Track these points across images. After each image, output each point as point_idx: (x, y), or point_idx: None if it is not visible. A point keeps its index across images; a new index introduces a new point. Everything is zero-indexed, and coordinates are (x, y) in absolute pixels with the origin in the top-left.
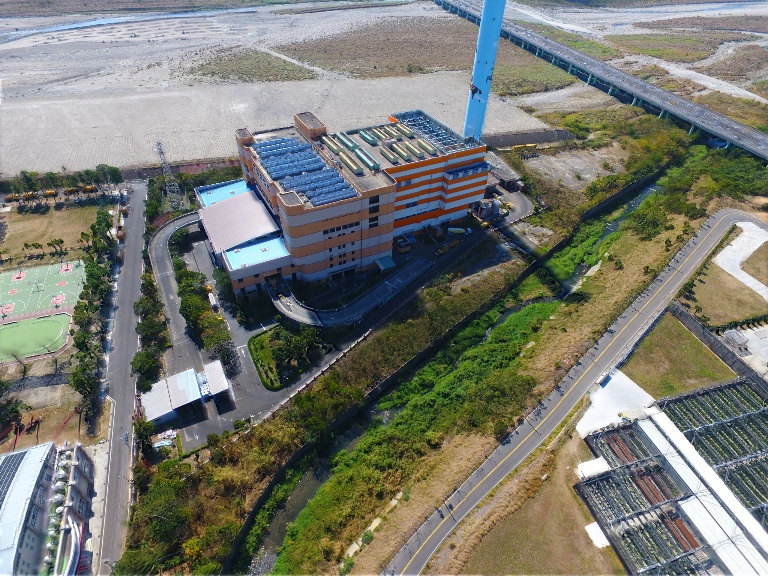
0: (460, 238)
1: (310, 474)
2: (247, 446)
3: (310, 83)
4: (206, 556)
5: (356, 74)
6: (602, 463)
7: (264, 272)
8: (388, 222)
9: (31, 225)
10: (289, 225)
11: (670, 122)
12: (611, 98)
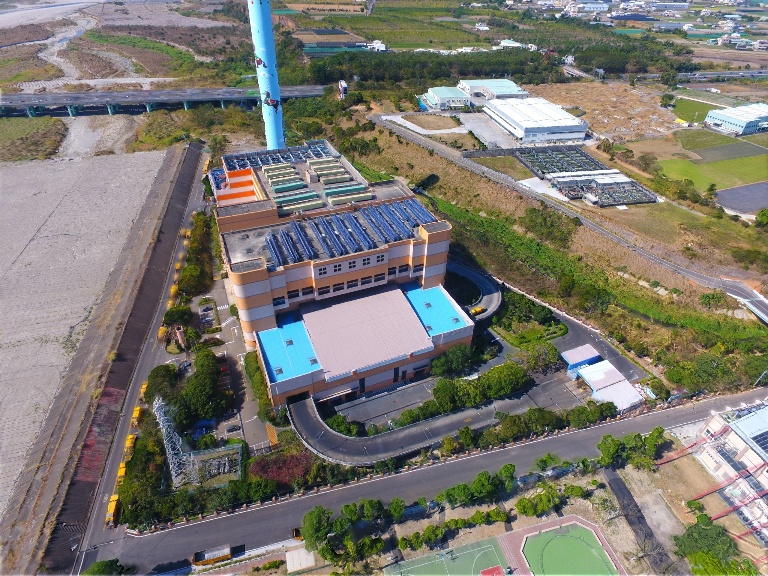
0: None
1: None
2: None
3: None
4: (718, 340)
5: None
6: (588, 194)
7: None
8: None
9: None
10: None
11: (211, 105)
12: (121, 116)
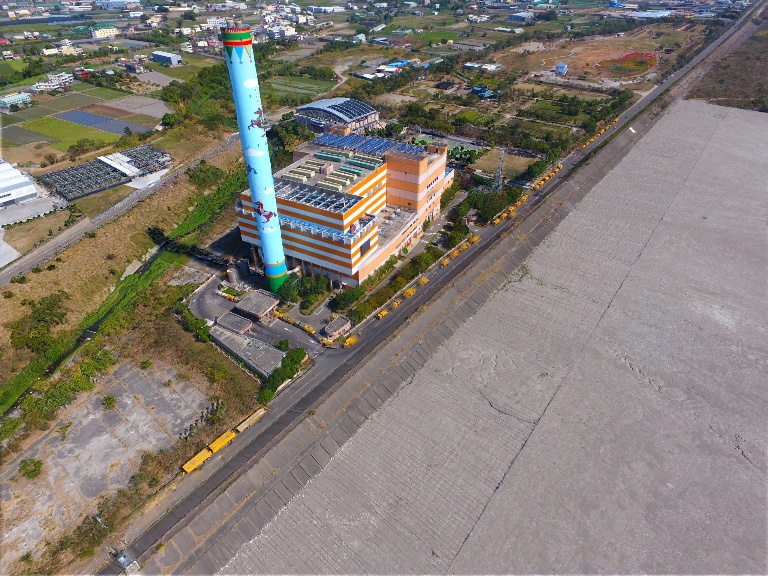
0: None
1: None
2: None
3: None
4: None
5: None
6: None
7: None
8: None
9: (519, 161)
10: None
11: None
12: None
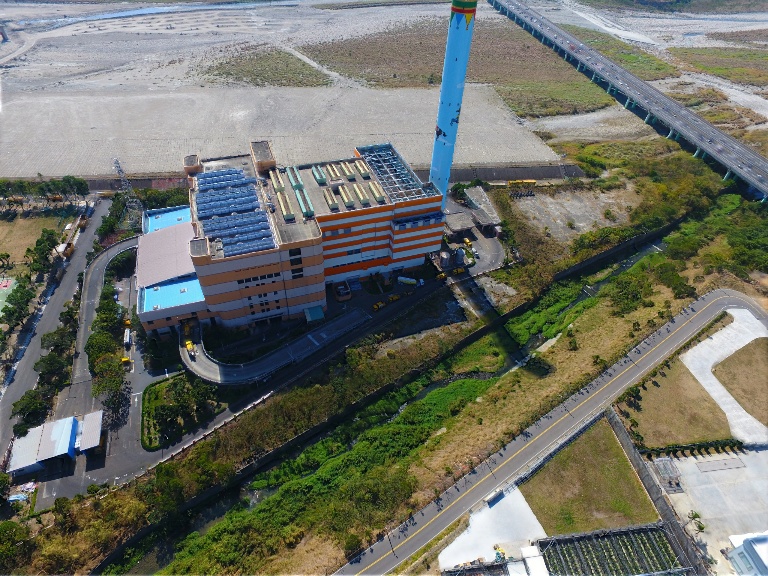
0: (408, 290)
1: (152, 555)
2: (93, 516)
3: (320, 90)
4: None
5: (372, 82)
6: None
7: (177, 315)
8: (315, 273)
9: None
10: (197, 274)
11: (702, 164)
12: (646, 127)
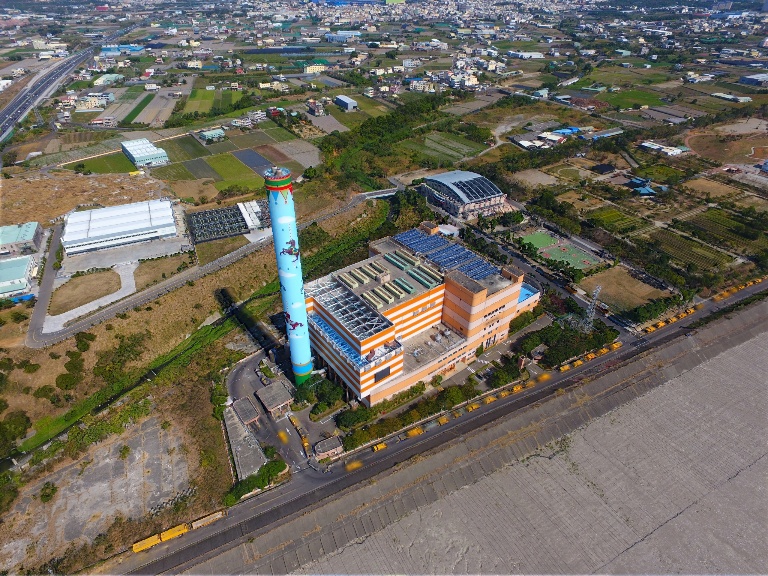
0: None
1: None
2: None
3: None
4: None
5: None
6: None
7: None
8: None
9: (641, 290)
10: None
11: None
12: None
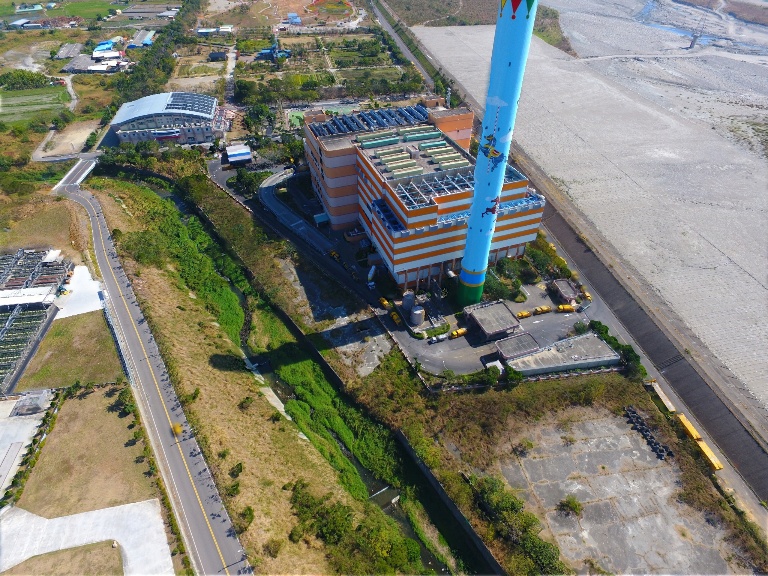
0: (358, 275)
1: None
2: None
3: None
4: None
5: None
6: None
7: None
8: None
9: None
10: None
11: None
12: None
